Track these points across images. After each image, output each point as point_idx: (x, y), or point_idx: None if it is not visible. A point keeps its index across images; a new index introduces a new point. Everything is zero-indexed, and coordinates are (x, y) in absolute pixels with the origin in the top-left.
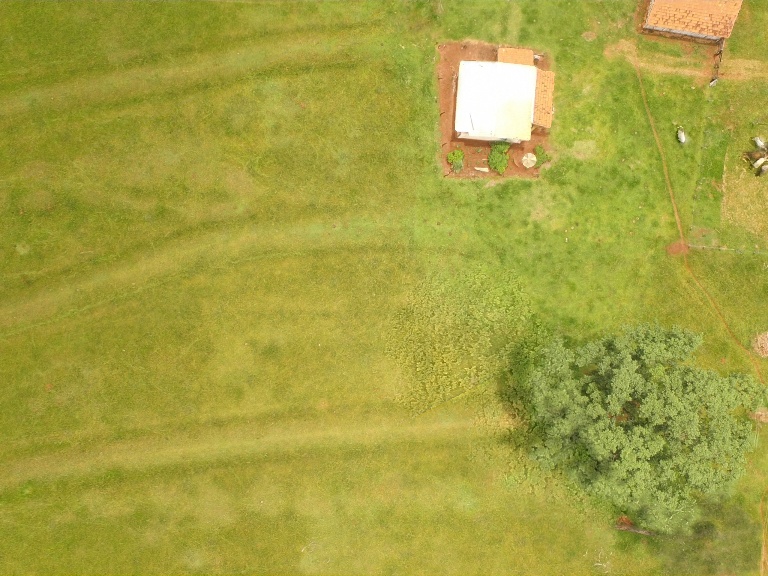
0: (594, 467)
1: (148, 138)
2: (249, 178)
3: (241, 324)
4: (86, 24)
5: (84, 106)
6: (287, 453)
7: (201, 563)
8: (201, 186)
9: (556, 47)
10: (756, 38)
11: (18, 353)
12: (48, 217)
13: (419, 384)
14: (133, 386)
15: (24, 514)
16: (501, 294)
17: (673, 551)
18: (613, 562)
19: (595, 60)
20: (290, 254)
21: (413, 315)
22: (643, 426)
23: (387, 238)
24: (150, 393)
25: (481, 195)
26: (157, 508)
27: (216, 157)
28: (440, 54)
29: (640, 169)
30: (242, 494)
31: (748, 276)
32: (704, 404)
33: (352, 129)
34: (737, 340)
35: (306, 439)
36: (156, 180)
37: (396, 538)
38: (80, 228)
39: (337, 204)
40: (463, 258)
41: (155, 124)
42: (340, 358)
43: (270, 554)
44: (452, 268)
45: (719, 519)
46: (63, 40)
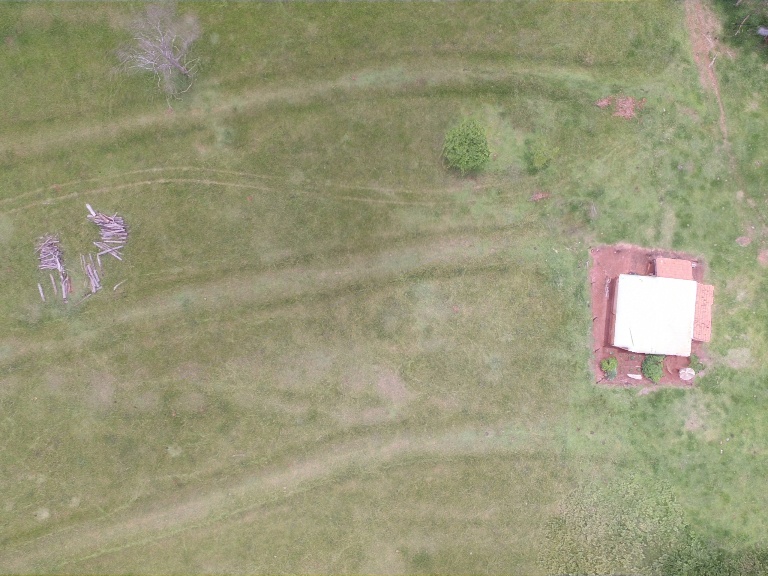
0: None
1: (300, 340)
2: (401, 382)
3: (392, 531)
4: (238, 223)
5: (236, 306)
6: None
7: None
8: (354, 391)
9: (710, 252)
10: None
11: (169, 557)
12: (200, 419)
13: None
14: None
15: None
16: (654, 504)
17: None
18: None
19: (749, 266)
20: (441, 460)
21: (565, 525)
22: None
23: (540, 446)
24: None
25: (634, 403)
26: None
27: (368, 360)
28: (593, 258)
29: None
30: None
31: None
32: None
33: (504, 333)
34: None
35: None
36: (308, 383)
37: None
38: (232, 431)
39: (490, 411)
40: (616, 467)
41: (307, 326)
42: (492, 568)
43: None
44: (605, 477)
45: None
46: (216, 239)
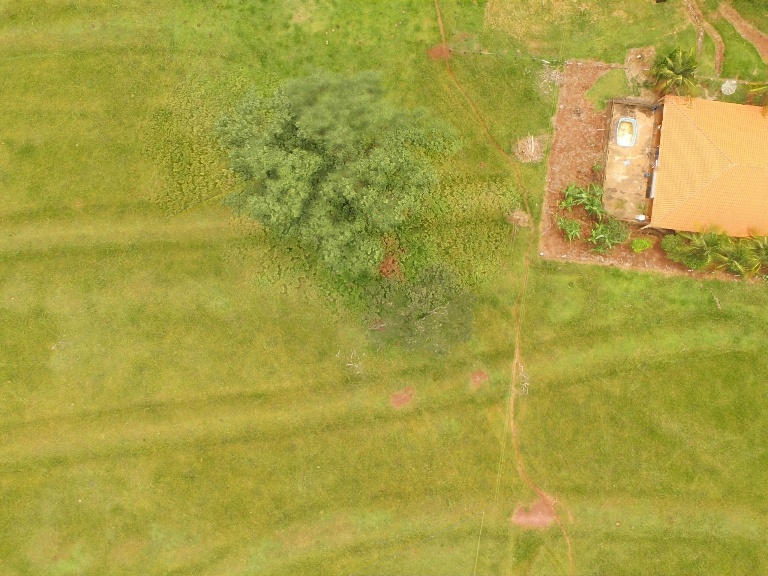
0: (348, 268)
1: None
2: None
3: None
4: None
5: None
6: (40, 251)
7: None
8: None
9: None
10: None
11: None
12: None
13: (176, 185)
14: None
15: None
16: (261, 97)
17: (426, 352)
18: (365, 363)
19: None
20: (50, 55)
21: (172, 116)
22: (399, 228)
23: (147, 39)
24: None
25: None
26: None
27: None
28: None
29: None
30: None
31: (509, 81)
32: (461, 207)
33: None
34: (497, 145)
35: (59, 237)
36: None
37: (147, 336)
38: None
39: (97, 4)
40: (224, 61)
41: None
42: (97, 158)
43: (19, 350)
44: (212, 70)
45: (472, 321)
46: None
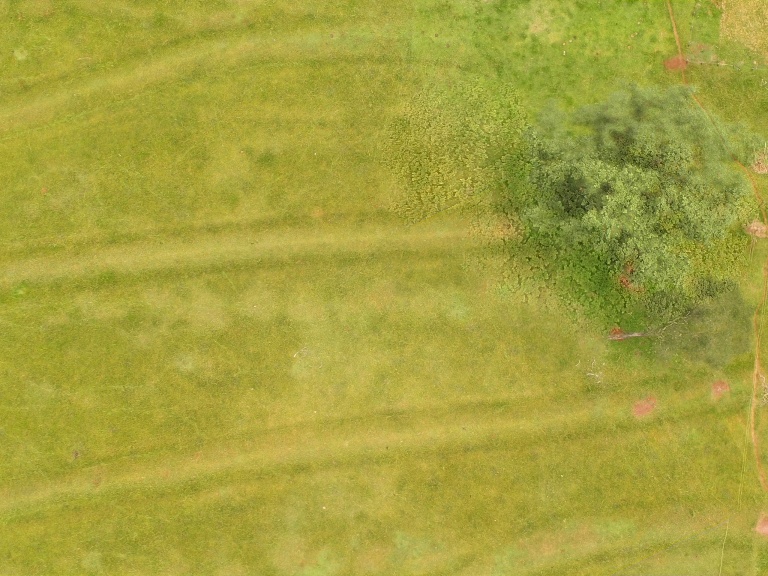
0: (588, 277)
1: None
2: None
3: (237, 132)
4: None
5: None
6: (281, 259)
7: (193, 366)
8: None
9: None
10: None
11: (14, 156)
12: (46, 23)
13: (414, 194)
14: (128, 191)
15: (18, 314)
16: (498, 107)
17: (666, 362)
18: (605, 372)
19: None
20: (287, 64)
21: (409, 126)
22: (638, 238)
23: (385, 49)
24: (145, 198)
25: (479, 8)
26: (150, 310)
27: None
28: None
29: None
30: (235, 298)
31: (746, 92)
32: (699, 217)
33: None
34: (734, 156)
35: (300, 245)
36: None
37: (389, 344)
38: (78, 34)
39: (335, 14)
40: (460, 71)
41: None
42: (336, 167)
43: (262, 358)
44: (449, 80)
45: (713, 331)
46: None
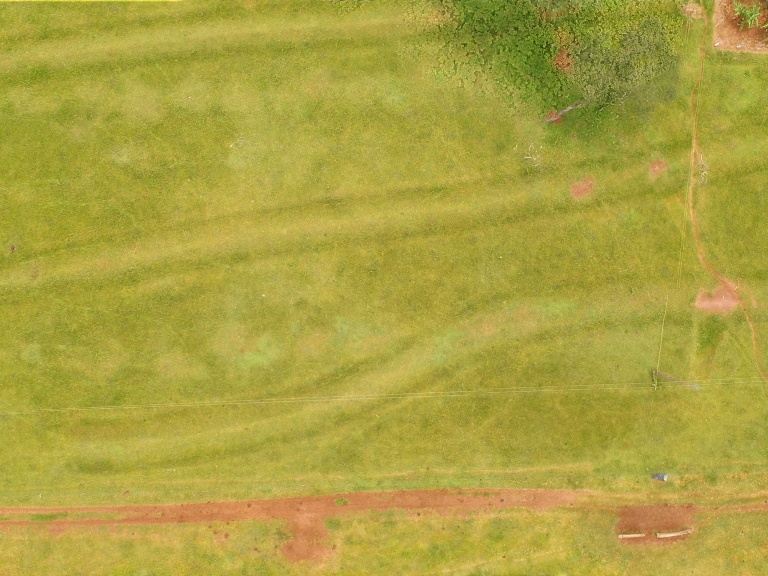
0: (524, 61)
1: None
2: None
3: None
4: None
5: None
6: (215, 51)
7: (129, 158)
8: None
9: None
10: None
11: None
12: None
13: None
14: None
15: None
16: None
17: (603, 144)
18: (543, 155)
19: None
20: None
21: None
22: (573, 22)
23: None
24: None
25: None
26: (84, 104)
27: None
28: None
29: None
30: (170, 90)
31: None
32: None
33: None
34: None
35: (234, 36)
36: None
37: (325, 132)
38: None
39: None
40: None
41: None
42: None
43: (198, 149)
44: None
45: (649, 111)
46: None
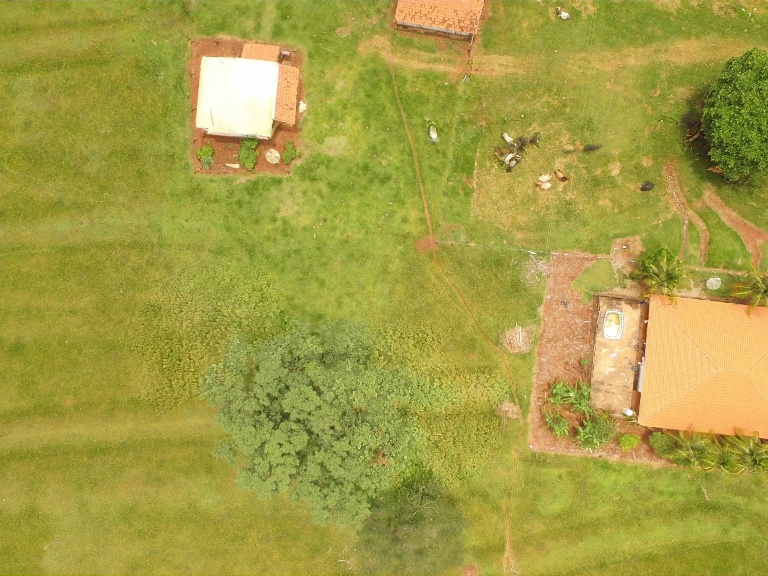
0: (338, 463)
1: None
2: None
3: None
4: None
5: None
6: (31, 451)
7: None
8: None
9: (309, 43)
10: (510, 34)
11: None
12: None
13: (166, 381)
14: None
15: None
16: (250, 290)
17: (417, 547)
18: (357, 558)
19: (349, 56)
20: (38, 251)
21: (161, 312)
22: (389, 422)
23: (135, 235)
24: None
25: (231, 191)
26: None
27: None
28: (192, 50)
29: (392, 165)
30: None
31: (496, 272)
32: (450, 400)
33: (103, 125)
34: (485, 336)
35: (50, 436)
36: None
37: (138, 535)
38: None
39: (85, 200)
40: (213, 254)
41: None
42: (86, 355)
43: (11, 552)
44: (201, 264)
45: (463, 515)
46: None
